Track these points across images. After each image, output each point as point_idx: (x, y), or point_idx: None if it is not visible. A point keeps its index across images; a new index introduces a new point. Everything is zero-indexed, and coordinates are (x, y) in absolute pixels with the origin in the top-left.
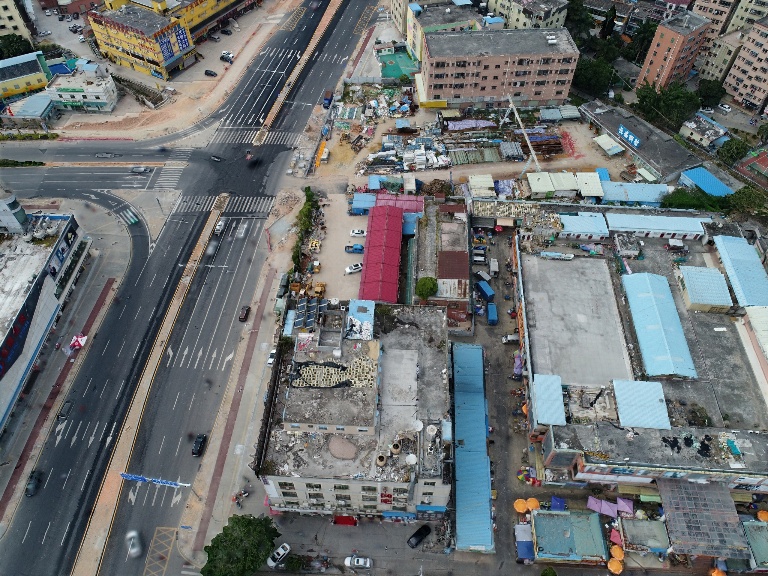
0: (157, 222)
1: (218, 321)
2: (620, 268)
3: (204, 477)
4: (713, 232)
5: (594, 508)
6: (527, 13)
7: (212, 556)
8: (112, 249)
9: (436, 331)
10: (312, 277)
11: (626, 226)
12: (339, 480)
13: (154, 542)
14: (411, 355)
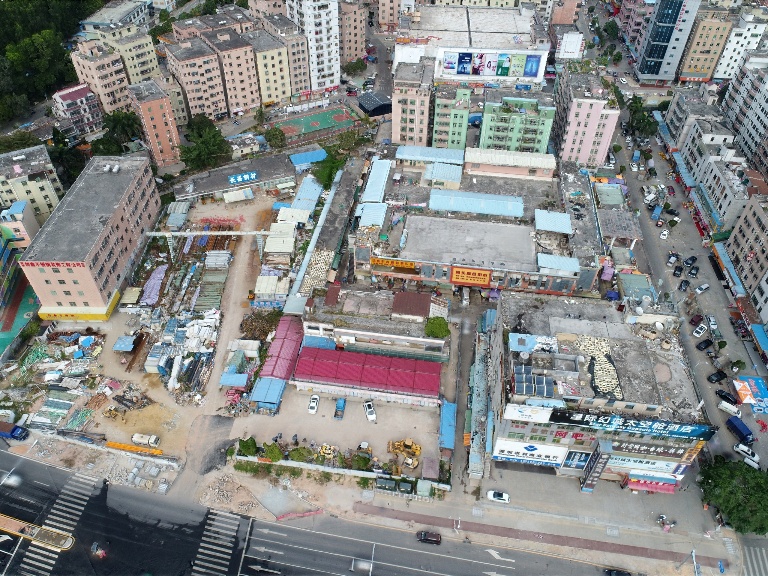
0: None
1: (439, 574)
2: (417, 210)
3: (652, 567)
4: (390, 157)
5: (610, 277)
6: (37, 177)
7: (762, 509)
8: None
9: (525, 303)
10: (377, 457)
11: (380, 193)
12: None
13: None
14: (555, 321)
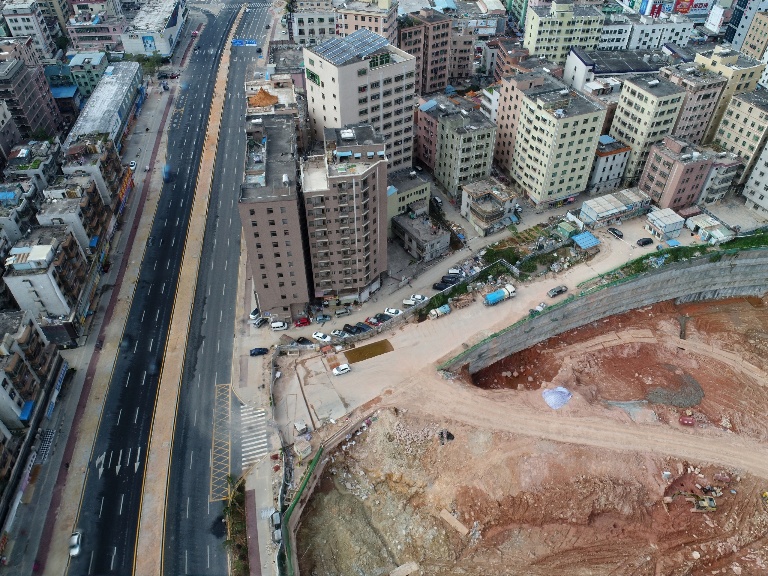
0: (216, 11)
1: (256, 29)
2: None
3: None
4: None
5: None
6: None
7: None
8: (197, 17)
9: None
10: None
11: None
12: (320, 13)
13: (248, 66)
14: None
